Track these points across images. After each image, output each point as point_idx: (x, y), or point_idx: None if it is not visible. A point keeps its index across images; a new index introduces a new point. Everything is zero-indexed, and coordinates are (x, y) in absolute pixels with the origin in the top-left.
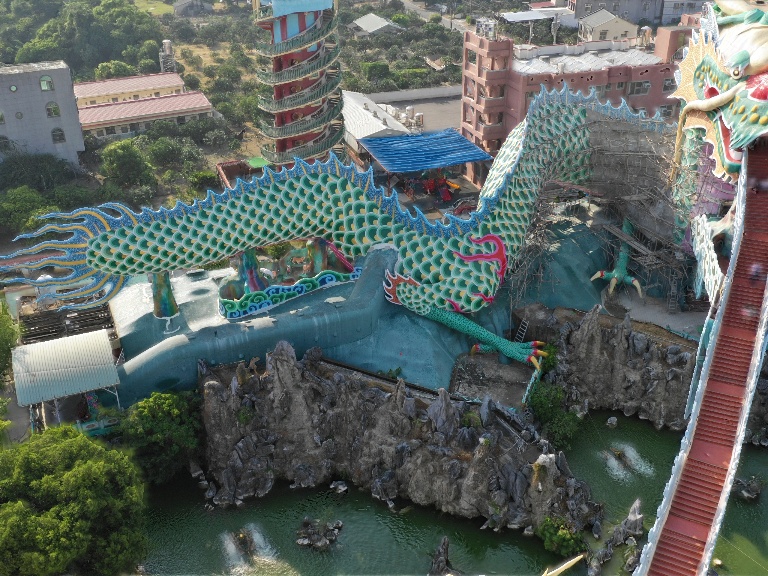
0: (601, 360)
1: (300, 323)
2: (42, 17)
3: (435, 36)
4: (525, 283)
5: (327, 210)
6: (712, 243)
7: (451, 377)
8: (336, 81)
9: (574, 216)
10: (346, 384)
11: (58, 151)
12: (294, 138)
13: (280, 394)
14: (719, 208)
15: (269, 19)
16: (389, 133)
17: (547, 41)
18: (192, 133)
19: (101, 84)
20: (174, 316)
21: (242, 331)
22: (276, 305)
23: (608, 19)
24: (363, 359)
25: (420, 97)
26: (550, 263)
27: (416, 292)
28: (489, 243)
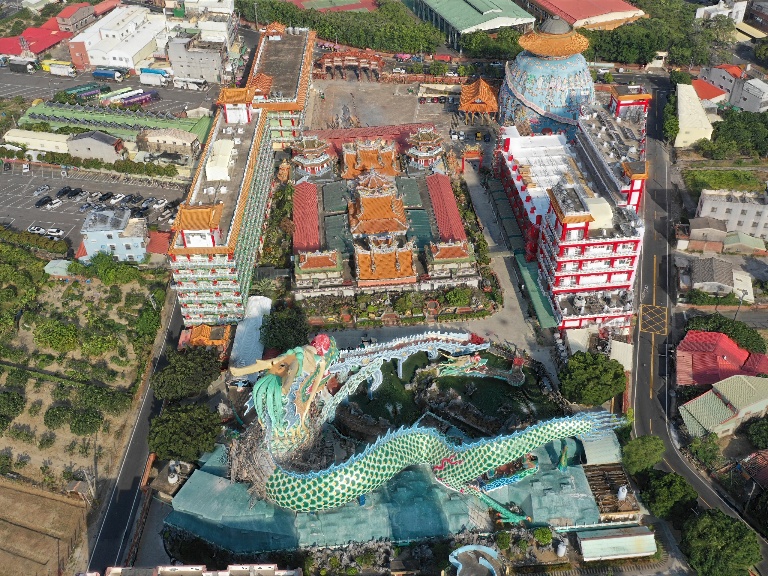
0: None
1: None
2: None
3: None
4: None
5: None
6: None
7: None
8: None
9: None
10: None
11: None
12: None
13: None
14: None
15: None
16: None
17: None
18: None
19: None
20: None
21: None
22: None
23: None
24: None
25: None
26: None
27: None
28: None
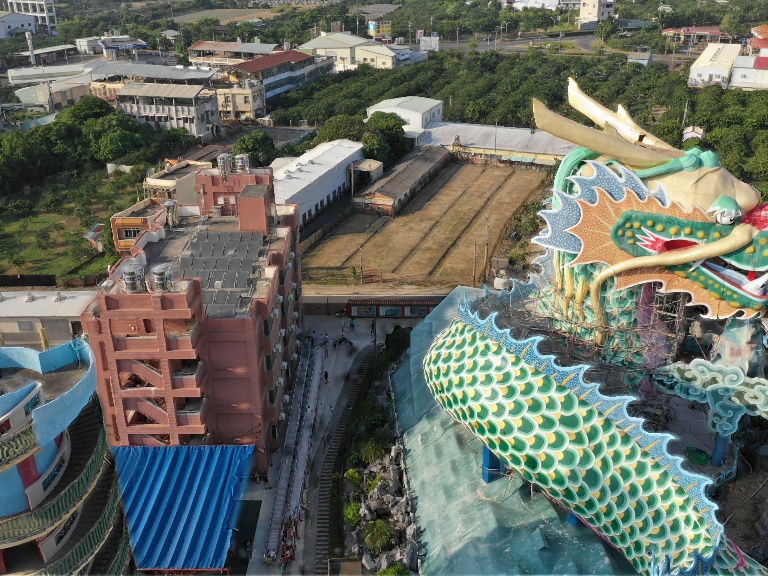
0: None
1: None
2: None
3: None
4: None
5: None
6: (761, 378)
7: None
8: None
9: None
10: None
11: None
12: None
13: None
14: (676, 347)
15: (23, 459)
16: None
17: None
18: None
19: None
20: None
21: None
22: None
23: None
24: None
25: None
26: None
27: None
28: None
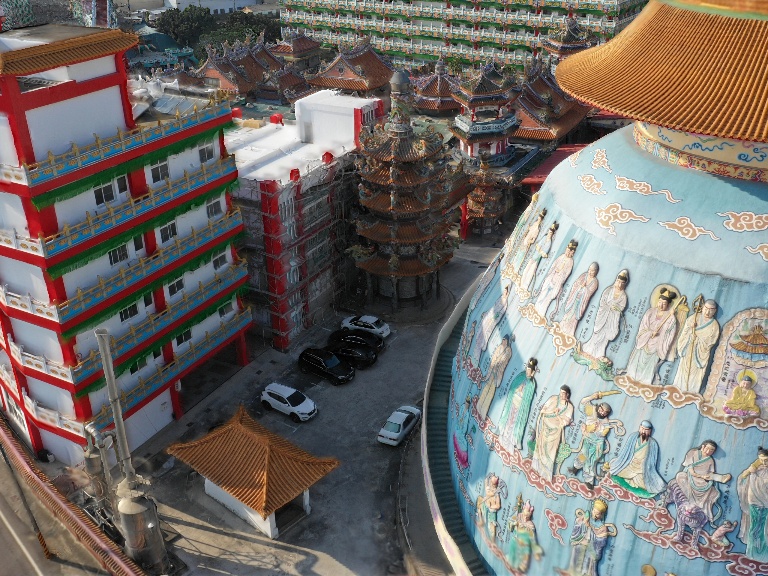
0: None
1: None
2: None
3: None
4: None
5: None
6: (91, 20)
7: None
8: None
9: None
10: None
11: None
12: None
13: None
14: None
15: None
16: None
17: None
18: None
19: None
20: None
21: None
22: None
23: None
24: None
25: None
26: None
27: None
28: None
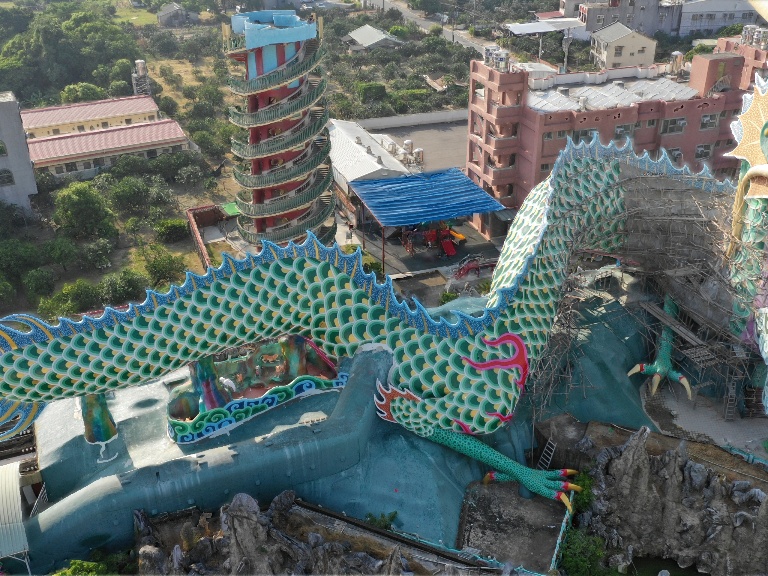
0: (649, 498)
1: (267, 456)
2: (10, 31)
3: (436, 51)
4: (550, 389)
5: (304, 304)
6: None
7: (459, 519)
8: (321, 122)
9: (605, 290)
10: (324, 548)
11: (6, 195)
12: (273, 187)
13: (238, 563)
14: None
15: (241, 51)
16: (384, 174)
17: (557, 56)
18: (163, 169)
19: (65, 110)
20: (110, 440)
21: (192, 470)
22: (240, 423)
23: (624, 34)
24: (348, 497)
25: (420, 122)
26: (580, 359)
27: (415, 410)
28: (507, 345)
